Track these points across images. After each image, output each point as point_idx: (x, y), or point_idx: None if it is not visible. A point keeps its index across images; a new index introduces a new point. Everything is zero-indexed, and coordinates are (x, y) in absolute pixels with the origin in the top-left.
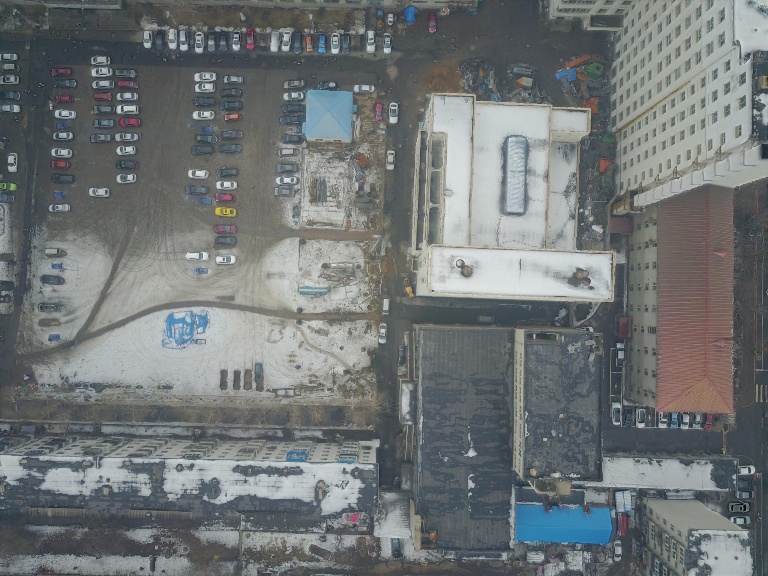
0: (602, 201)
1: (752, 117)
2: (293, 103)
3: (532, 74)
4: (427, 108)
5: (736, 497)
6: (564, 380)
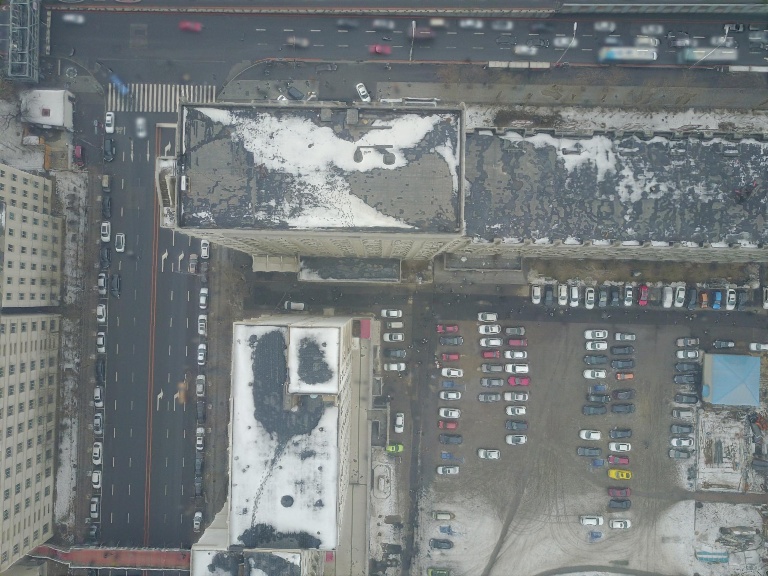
0: None
1: None
2: (686, 360)
3: None
4: None
5: None
6: None
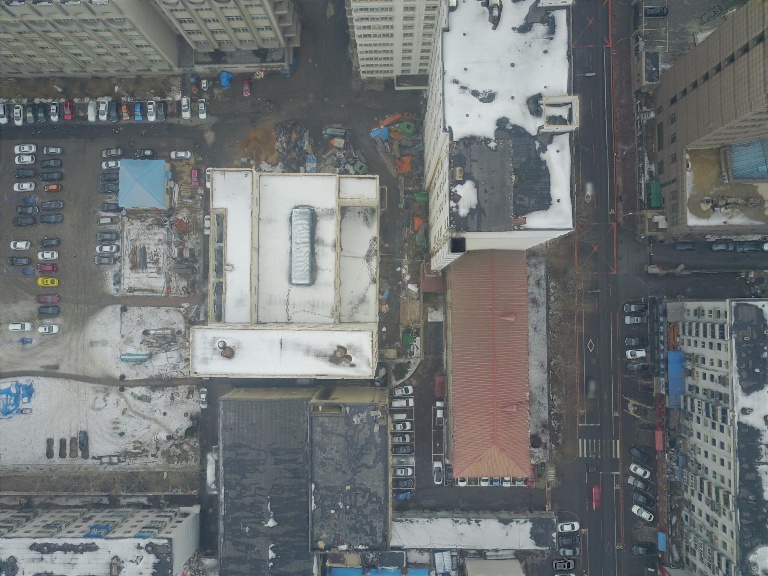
0: (417, 260)
1: (449, 208)
2: (112, 171)
3: (346, 134)
4: None
5: (560, 554)
6: (350, 451)
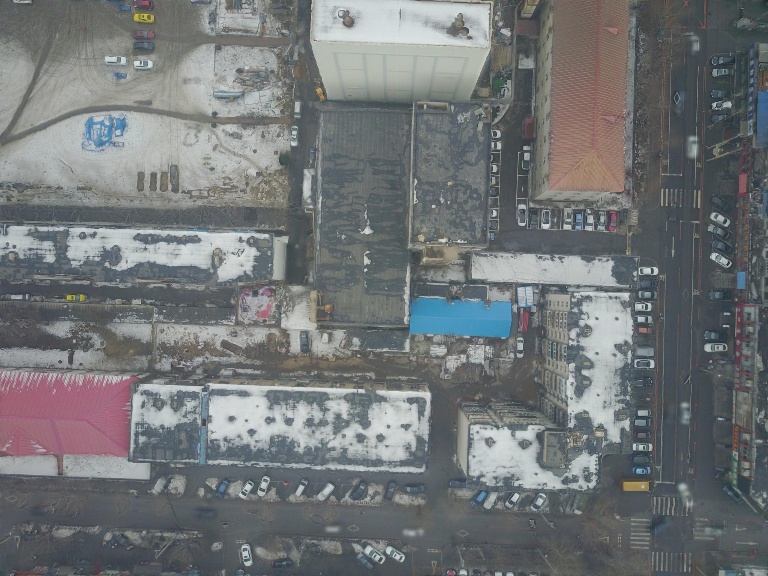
0: (511, 5)
1: None
2: None
3: None
4: None
5: (638, 297)
6: (453, 149)
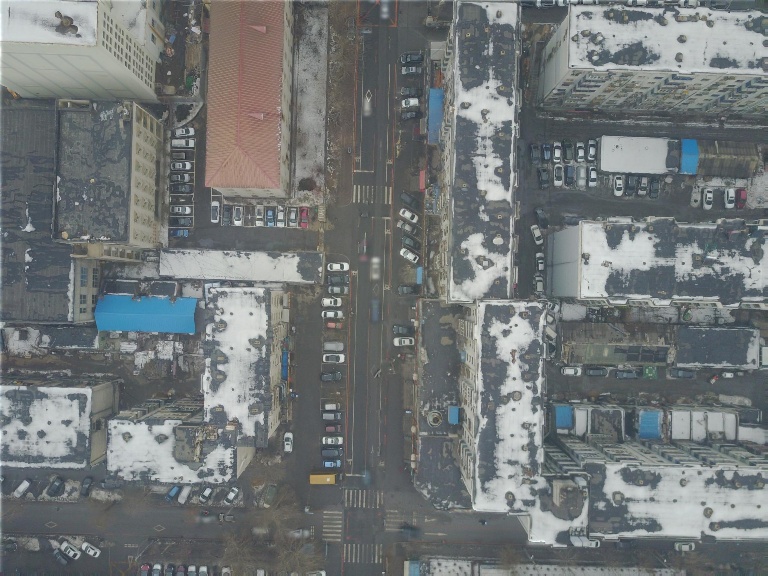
0: (201, 3)
1: None
2: None
3: None
4: None
5: (328, 292)
6: (96, 146)
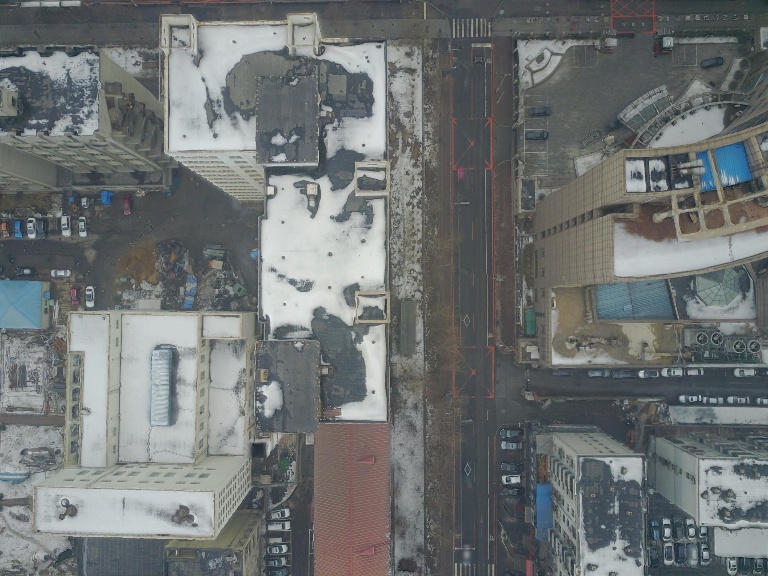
0: None
1: (255, 409)
2: None
3: (226, 254)
4: (124, 290)
5: None
6: None
